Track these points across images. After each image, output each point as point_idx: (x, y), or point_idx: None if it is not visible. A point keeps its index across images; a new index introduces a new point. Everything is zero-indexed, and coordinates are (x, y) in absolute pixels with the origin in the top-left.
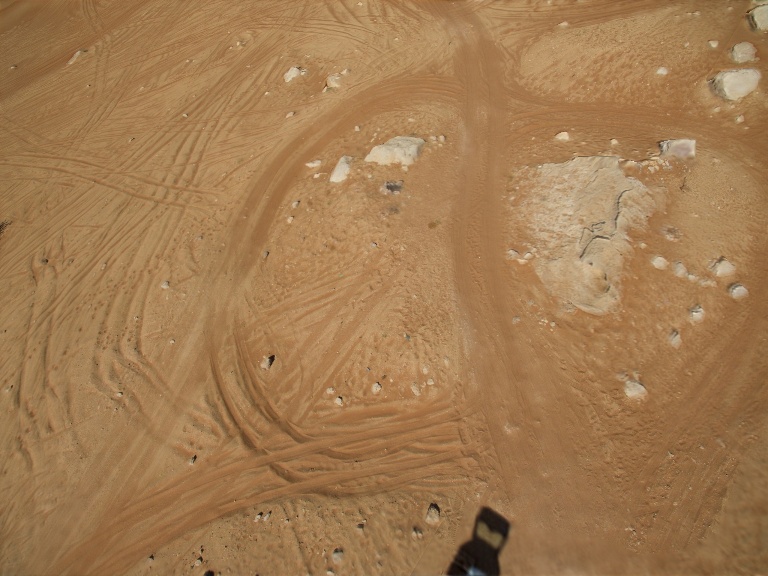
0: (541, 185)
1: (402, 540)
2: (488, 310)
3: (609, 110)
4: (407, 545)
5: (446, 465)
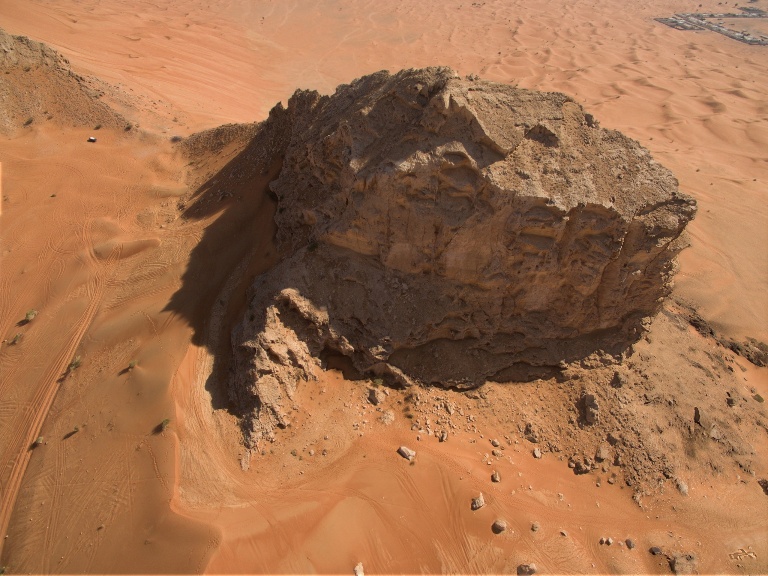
0: (683, 575)
1: (746, 568)
2: (710, 573)
3: (649, 570)
4: (745, 567)
5: (733, 567)
